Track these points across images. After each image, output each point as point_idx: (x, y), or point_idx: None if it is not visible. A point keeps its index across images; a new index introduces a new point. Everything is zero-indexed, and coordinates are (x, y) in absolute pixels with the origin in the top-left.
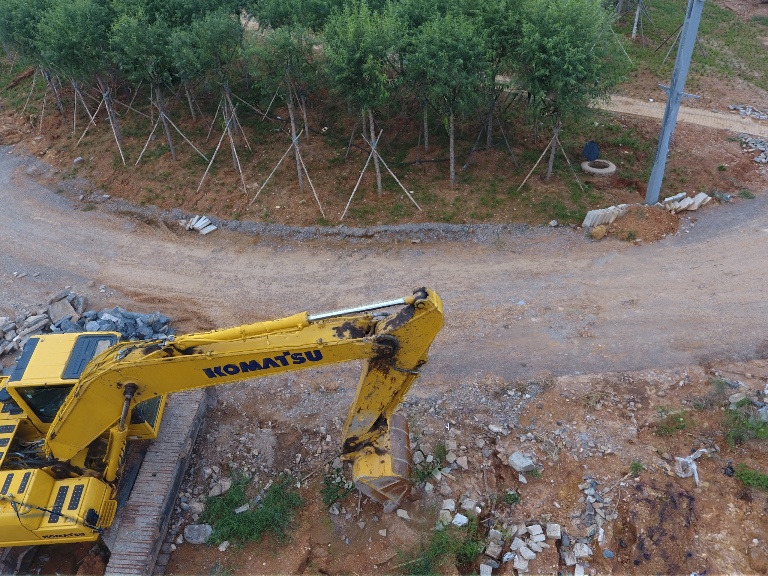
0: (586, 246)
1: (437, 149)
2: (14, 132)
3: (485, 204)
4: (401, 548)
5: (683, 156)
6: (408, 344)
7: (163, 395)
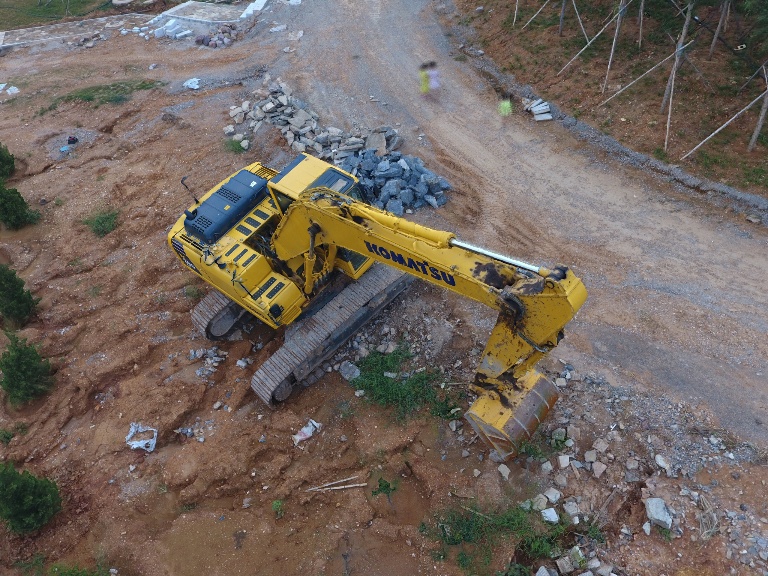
0: None
1: None
2: None
3: None
4: (480, 496)
5: None
6: (536, 317)
7: None
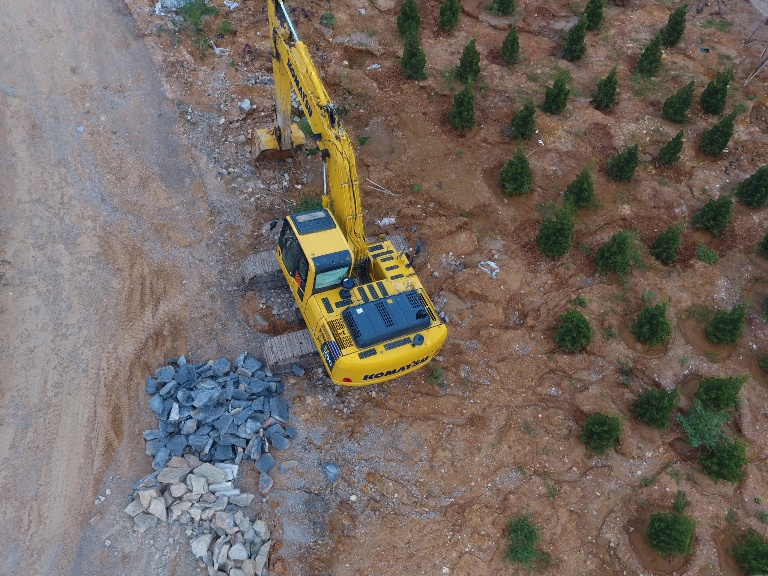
0: None
1: None
2: None
3: None
4: (316, 146)
5: None
6: None
7: None
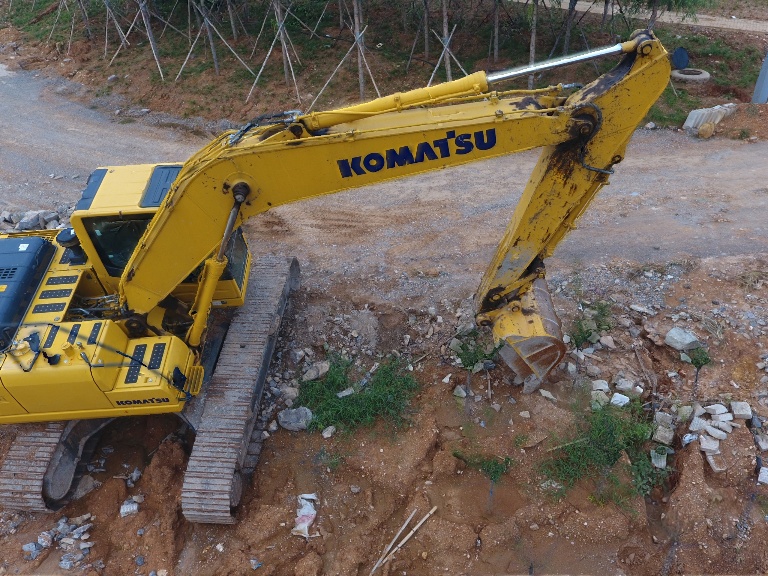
0: (693, 145)
1: (507, 60)
2: (39, 59)
3: None
4: (552, 430)
5: None
6: (610, 123)
7: (248, 259)
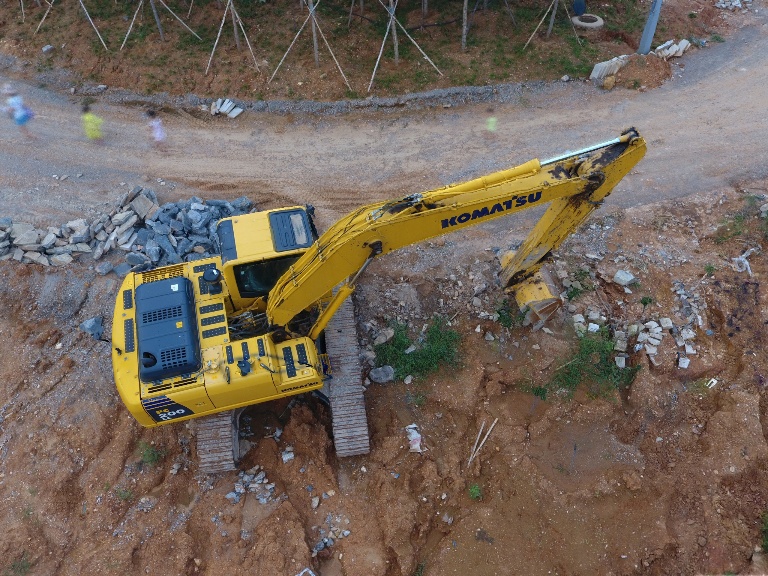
0: (601, 97)
1: (435, 12)
2: None
3: (499, 65)
4: (556, 355)
5: None
6: (608, 179)
7: None
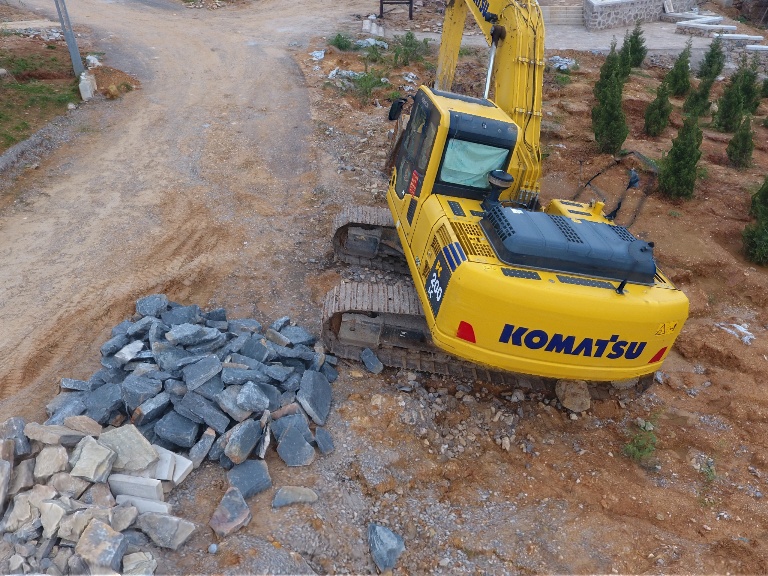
0: (126, 102)
1: None
2: None
3: (0, 121)
4: None
5: (9, 52)
6: None
7: None
